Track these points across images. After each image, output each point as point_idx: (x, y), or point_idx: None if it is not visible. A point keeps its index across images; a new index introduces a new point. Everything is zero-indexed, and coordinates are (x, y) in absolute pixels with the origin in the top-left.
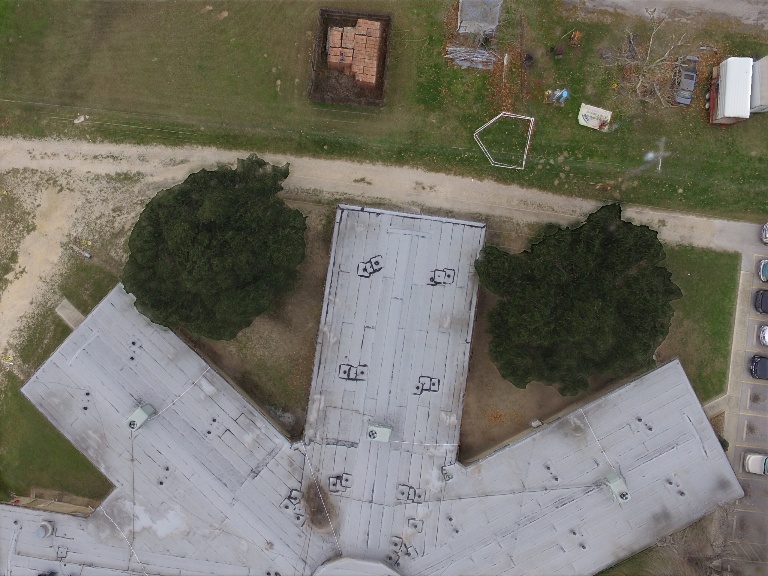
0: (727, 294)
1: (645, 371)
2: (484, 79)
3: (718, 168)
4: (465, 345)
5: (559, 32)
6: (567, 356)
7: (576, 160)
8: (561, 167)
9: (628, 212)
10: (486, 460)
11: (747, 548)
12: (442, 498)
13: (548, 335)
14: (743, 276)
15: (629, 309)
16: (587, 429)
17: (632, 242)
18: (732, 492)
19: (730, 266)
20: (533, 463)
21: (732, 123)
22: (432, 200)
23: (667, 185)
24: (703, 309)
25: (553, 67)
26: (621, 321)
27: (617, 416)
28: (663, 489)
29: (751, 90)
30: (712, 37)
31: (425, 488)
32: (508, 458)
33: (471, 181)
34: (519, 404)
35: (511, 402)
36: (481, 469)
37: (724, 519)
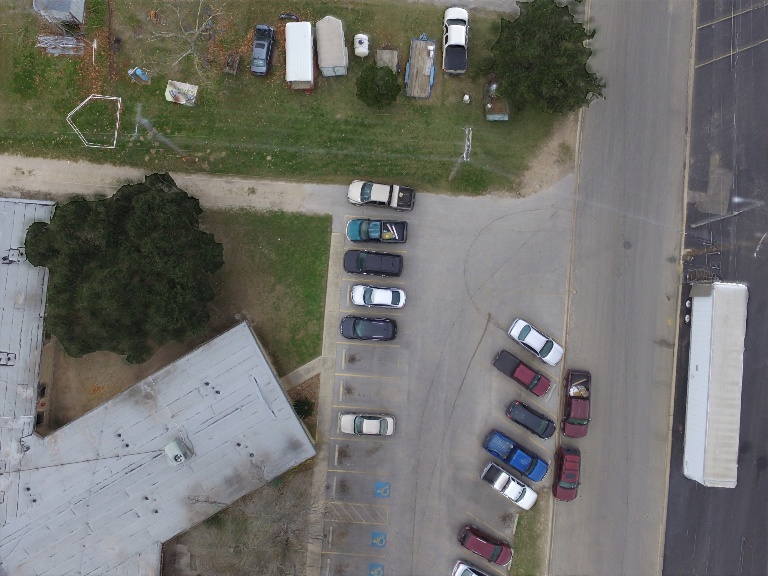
0: (317, 256)
1: (191, 334)
2: (75, 64)
3: (304, 133)
4: (39, 319)
5: (145, 13)
6: (94, 322)
7: (165, 135)
8: (151, 143)
9: (218, 182)
10: (61, 430)
11: (349, 509)
12: (20, 469)
13: (67, 302)
14: (334, 237)
15: (146, 273)
16: (157, 395)
17: (140, 207)
18: (302, 451)
19: (320, 228)
20: (105, 431)
21: (312, 87)
22: (31, 184)
23: (255, 153)
24: (294, 272)
25: (141, 47)
26: (140, 285)
27: (185, 381)
28: (233, 451)
29: (316, 53)
30: (293, 5)
31: (5, 460)
32: (82, 427)
33: (67, 163)
34: (116, 376)
35: (109, 374)
36: (57, 439)
37: (257, 476)
